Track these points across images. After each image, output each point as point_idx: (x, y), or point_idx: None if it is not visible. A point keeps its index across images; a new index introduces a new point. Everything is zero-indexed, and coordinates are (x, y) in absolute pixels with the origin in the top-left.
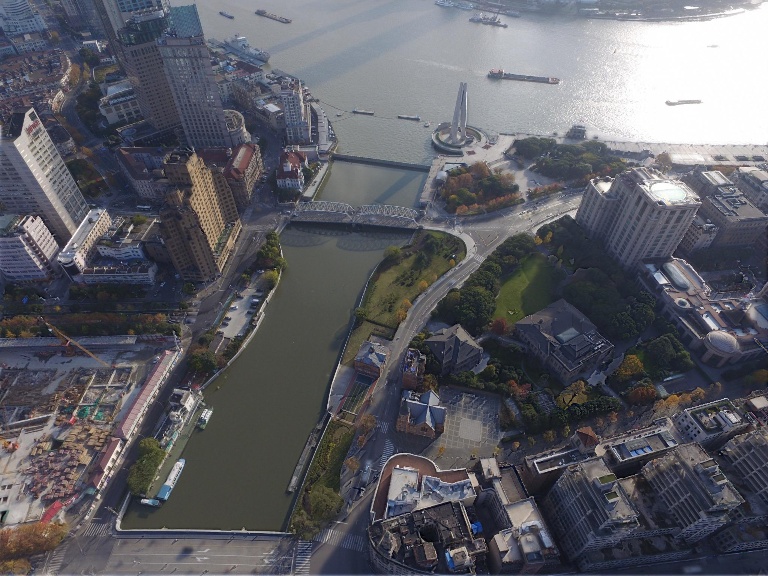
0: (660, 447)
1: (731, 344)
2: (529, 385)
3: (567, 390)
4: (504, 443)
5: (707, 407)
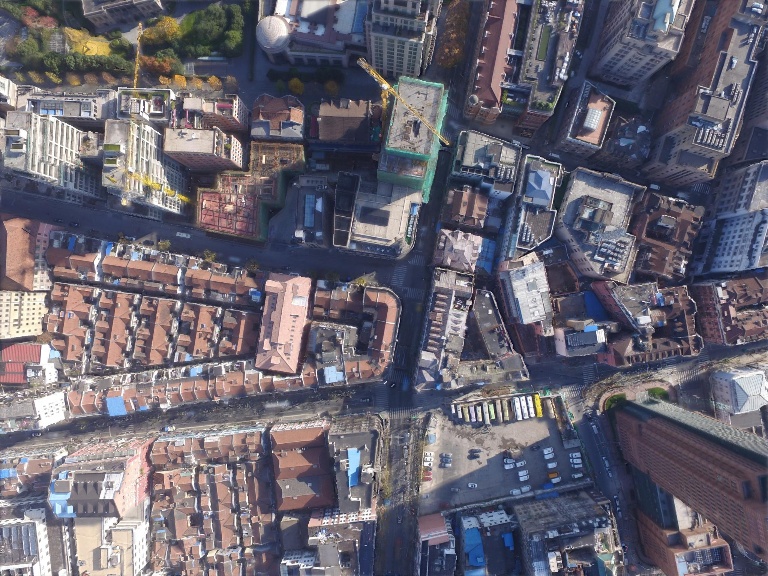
0: (72, 114)
1: (269, 37)
2: (49, 19)
3: (94, 37)
4: (1, 71)
5: (139, 91)
